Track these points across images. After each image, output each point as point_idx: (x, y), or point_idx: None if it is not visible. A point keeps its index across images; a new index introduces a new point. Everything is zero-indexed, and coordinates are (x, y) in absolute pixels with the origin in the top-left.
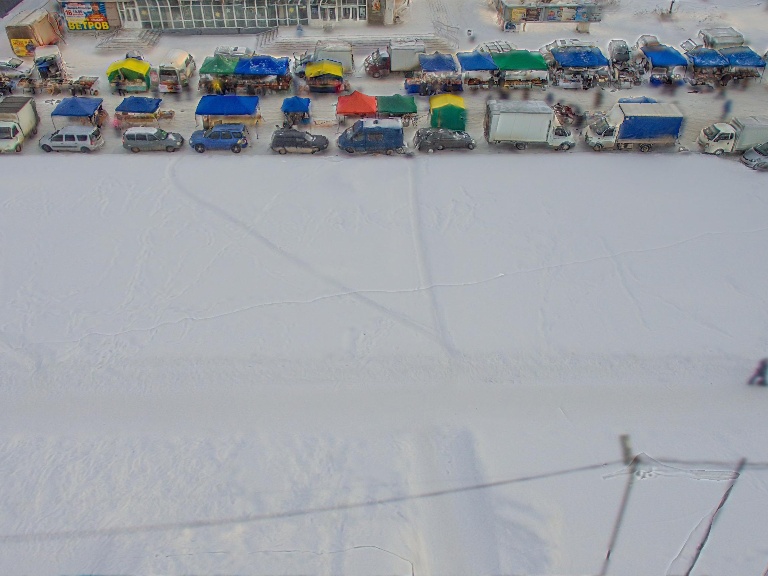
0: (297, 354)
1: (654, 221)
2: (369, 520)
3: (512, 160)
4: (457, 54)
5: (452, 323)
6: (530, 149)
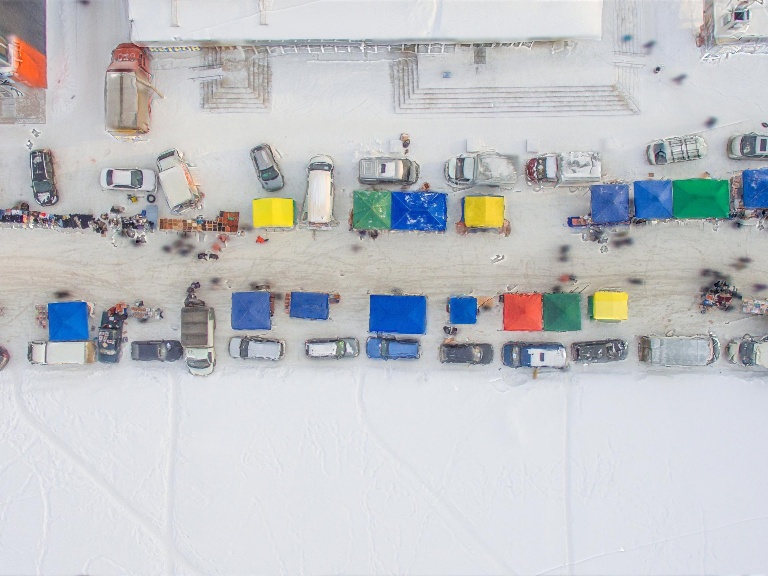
0: None
1: (749, 490)
2: None
3: (656, 390)
4: (635, 185)
5: None
6: None
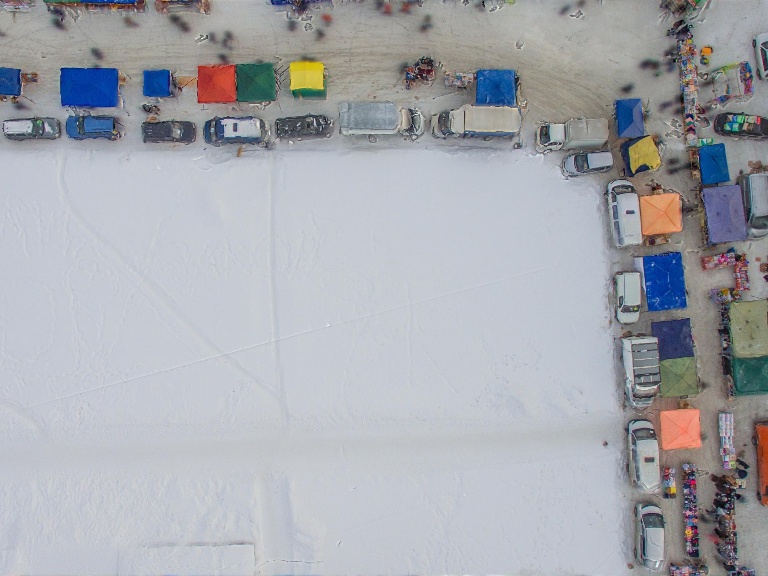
0: (193, 416)
1: (453, 262)
2: (237, 522)
3: (360, 165)
4: None
5: (288, 383)
6: (381, 141)
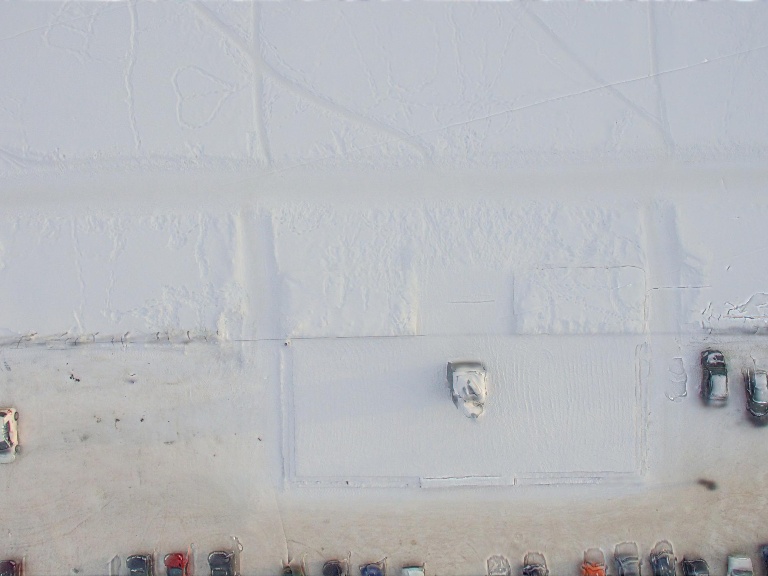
0: (581, 144)
1: None
2: (624, 248)
3: None
4: None
5: (671, 115)
6: None
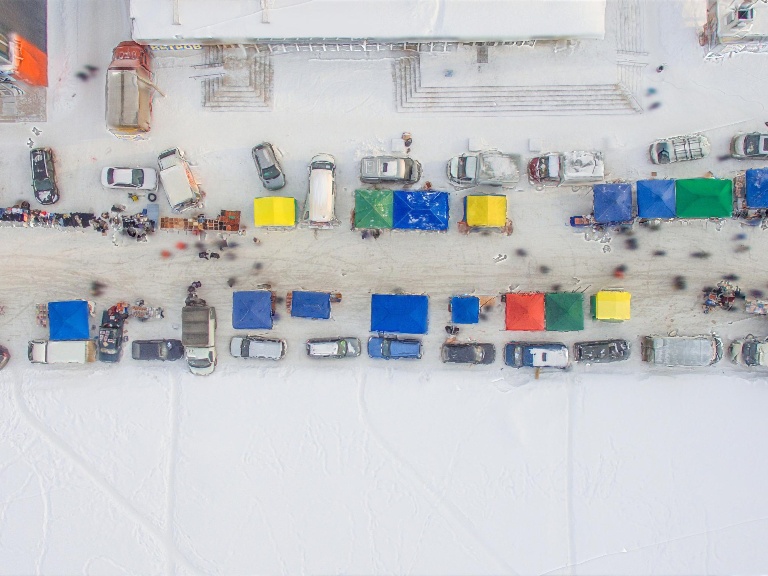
0: None
1: (752, 491)
2: None
3: (659, 390)
4: (638, 184)
5: None
6: None
